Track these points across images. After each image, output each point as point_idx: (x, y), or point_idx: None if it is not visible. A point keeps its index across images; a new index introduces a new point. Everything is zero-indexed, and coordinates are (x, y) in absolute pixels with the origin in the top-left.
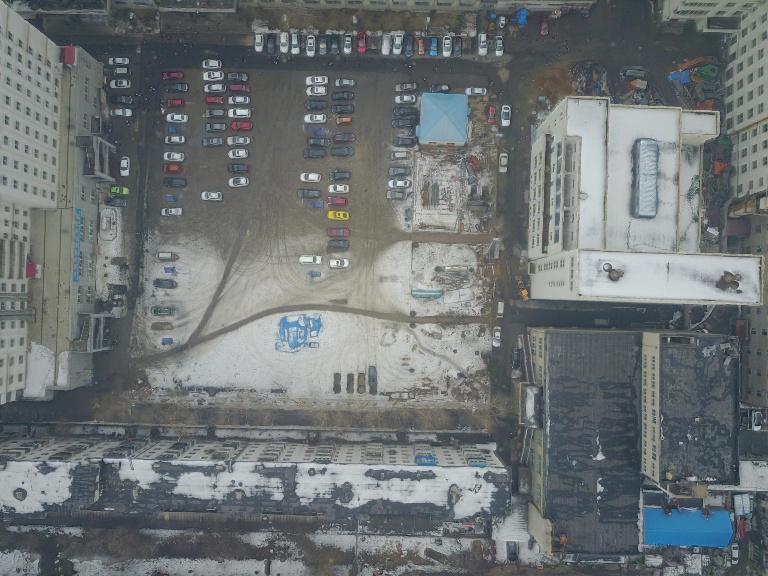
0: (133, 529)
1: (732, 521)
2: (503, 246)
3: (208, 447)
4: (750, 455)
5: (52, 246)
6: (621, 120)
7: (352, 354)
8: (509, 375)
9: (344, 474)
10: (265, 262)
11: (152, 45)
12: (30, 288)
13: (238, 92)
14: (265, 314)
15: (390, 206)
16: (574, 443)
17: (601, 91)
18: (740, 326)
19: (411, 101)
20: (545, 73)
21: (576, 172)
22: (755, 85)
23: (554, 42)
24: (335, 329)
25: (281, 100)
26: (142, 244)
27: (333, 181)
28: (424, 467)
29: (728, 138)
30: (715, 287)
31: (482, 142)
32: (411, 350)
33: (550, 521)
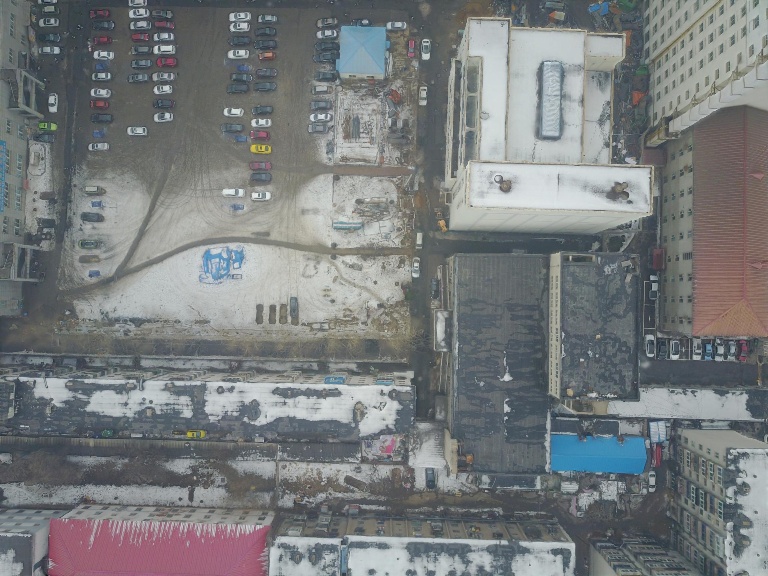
0: (58, 454)
1: (648, 448)
2: (423, 178)
3: (130, 373)
4: (668, 384)
5: None
6: (526, 43)
7: (274, 285)
8: (429, 306)
9: (252, 392)
10: (189, 196)
11: None
12: None
13: (163, 29)
14: (189, 247)
15: (312, 140)
16: (482, 364)
17: (520, 24)
18: (657, 255)
19: (332, 36)
20: (465, 7)
21: (478, 92)
22: (665, 10)
23: None
24: (258, 261)
25: (205, 37)
26: (70, 179)
27: (256, 116)
28: (330, 385)
29: (646, 68)
30: (605, 198)
31: (402, 76)
32: (332, 281)
33: (457, 441)
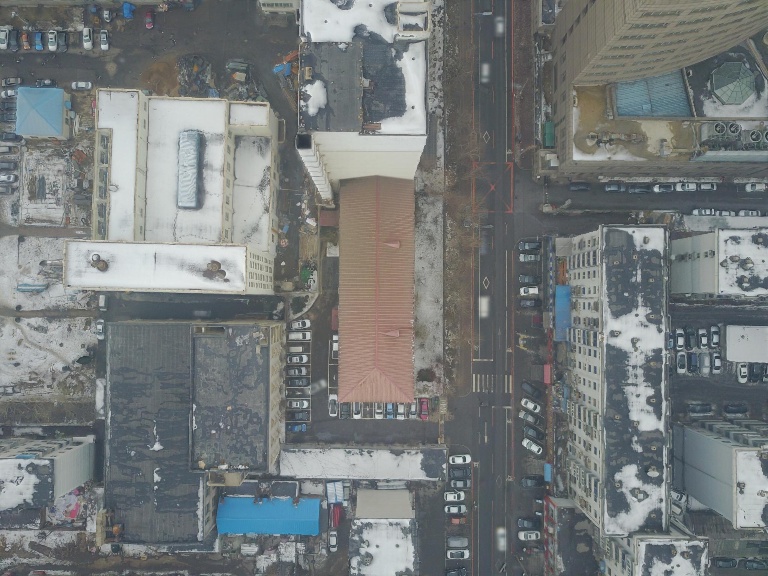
0: None
1: (325, 509)
2: None
3: None
4: (353, 443)
5: None
6: (168, 112)
7: None
8: None
9: None
10: None
11: None
12: None
13: None
14: None
15: None
16: (133, 434)
17: (206, 84)
18: (335, 316)
19: (16, 96)
20: (151, 67)
21: None
22: None
23: (161, 36)
24: None
25: None
26: None
27: None
28: None
29: None
30: (202, 276)
31: (89, 136)
32: (17, 344)
33: (106, 512)
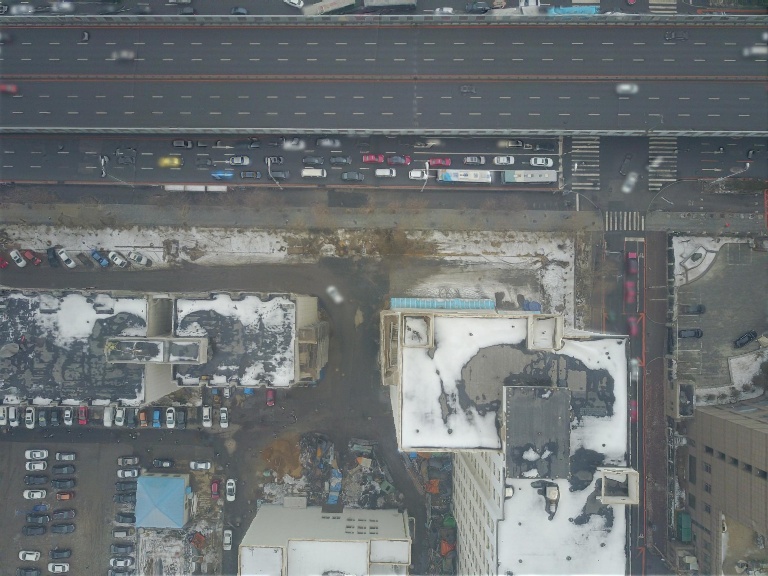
0: None
1: None
2: None
3: None
4: None
5: None
6: (308, 552)
7: None
8: None
9: None
10: None
11: None
12: None
13: None
14: None
15: None
16: None
17: (328, 464)
18: None
19: (133, 476)
20: (272, 445)
21: None
22: None
23: (281, 412)
24: None
25: (1, 473)
26: None
27: (53, 559)
28: None
29: (453, 519)
30: None
31: (207, 516)
32: None
33: None
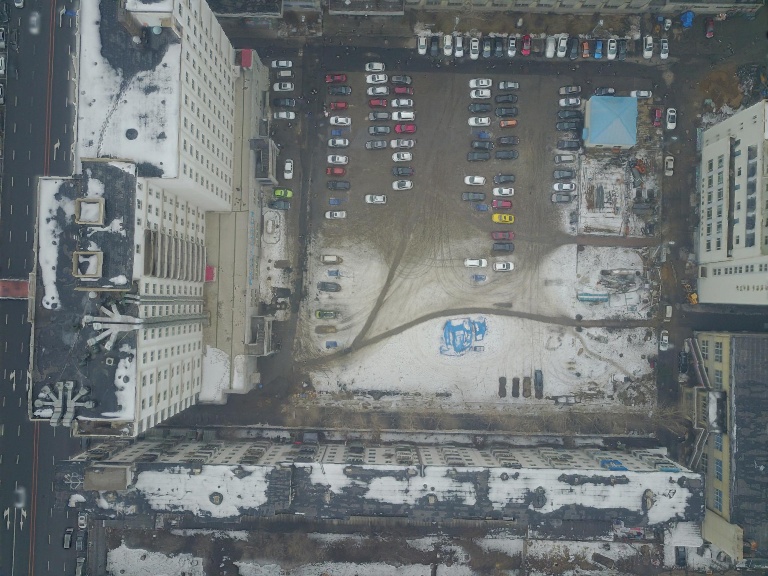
0: None
1: None
2: (669, 249)
3: (381, 451)
4: None
5: (226, 249)
6: None
7: (517, 358)
8: (676, 379)
9: (537, 479)
10: (429, 265)
11: (314, 48)
12: (205, 291)
13: (402, 95)
14: (429, 317)
15: (554, 209)
16: (762, 448)
17: (767, 94)
18: None
19: (576, 104)
20: (710, 76)
21: None
22: None
23: (719, 45)
24: (500, 333)
25: (444, 103)
26: (305, 247)
27: (497, 184)
28: (617, 472)
29: None
30: None
31: (647, 145)
32: (577, 354)
33: (739, 526)
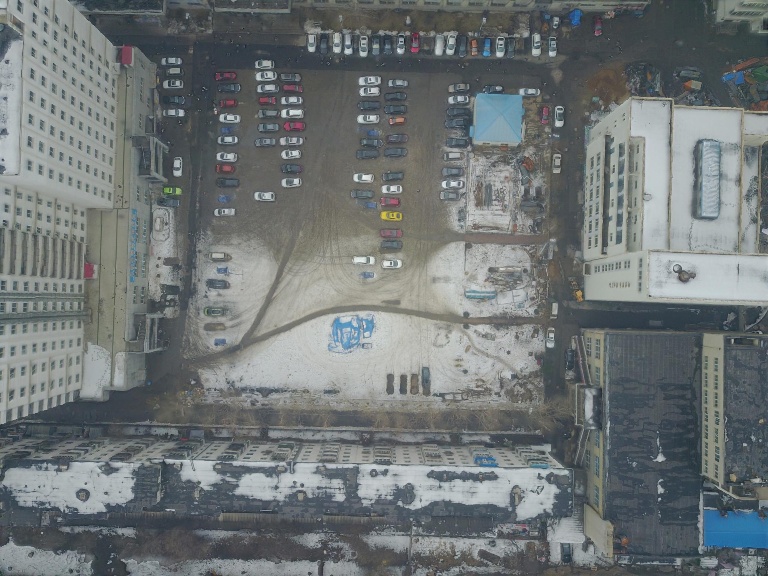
0: (188, 530)
1: None
2: (556, 247)
3: (263, 448)
4: None
5: (108, 246)
6: (683, 121)
7: (405, 355)
8: (563, 376)
9: (406, 475)
10: (318, 263)
11: (204, 45)
12: (86, 288)
13: (291, 92)
14: (318, 315)
15: (443, 207)
16: (634, 444)
17: (655, 92)
18: None
19: (464, 102)
20: (598, 74)
21: (640, 173)
22: None
23: (607, 43)
24: (388, 330)
25: (334, 100)
26: (195, 244)
27: (386, 182)
28: (486, 468)
29: None
30: None
31: (535, 143)
32: (464, 351)
33: (611, 523)
